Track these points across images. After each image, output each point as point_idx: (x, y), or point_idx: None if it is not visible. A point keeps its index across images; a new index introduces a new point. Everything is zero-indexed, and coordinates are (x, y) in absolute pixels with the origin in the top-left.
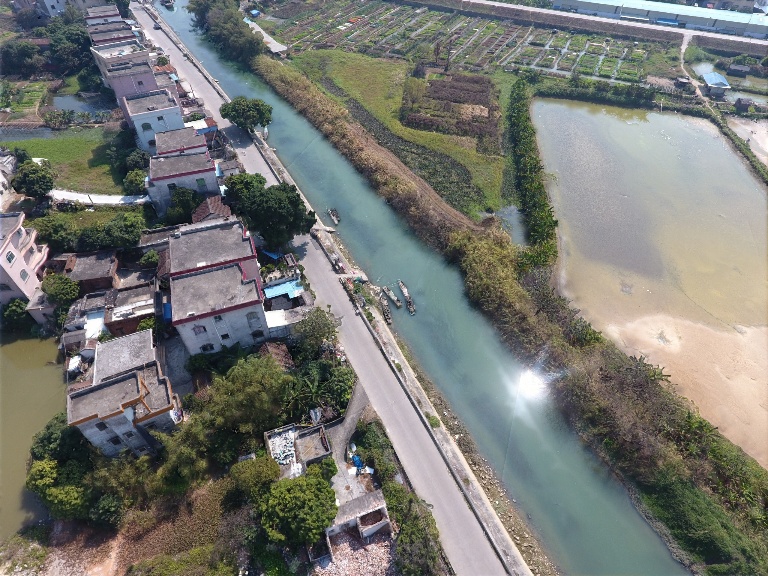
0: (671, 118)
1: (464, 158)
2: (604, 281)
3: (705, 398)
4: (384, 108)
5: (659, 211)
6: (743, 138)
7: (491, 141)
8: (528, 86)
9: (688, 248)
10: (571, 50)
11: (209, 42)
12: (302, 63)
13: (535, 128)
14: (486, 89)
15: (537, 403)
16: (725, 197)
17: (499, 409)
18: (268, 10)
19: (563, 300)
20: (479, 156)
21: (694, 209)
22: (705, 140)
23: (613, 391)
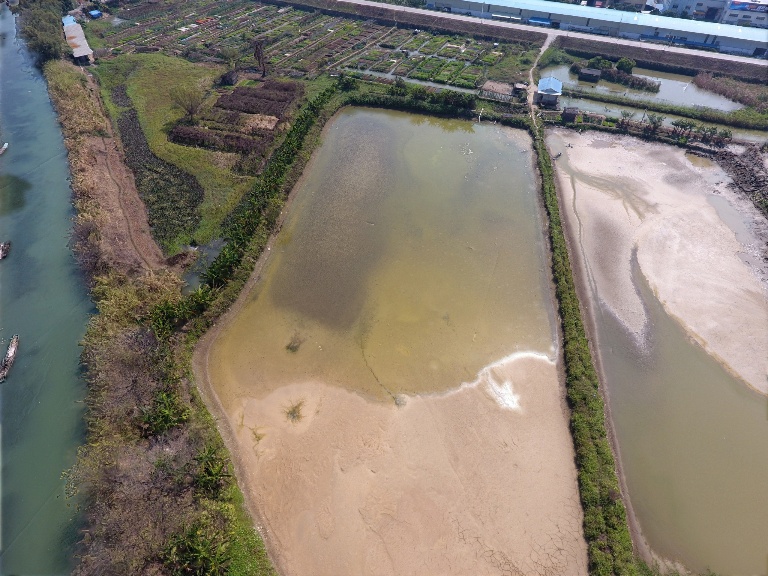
0: (487, 129)
1: (208, 179)
2: (274, 334)
3: (294, 500)
4: (160, 120)
5: (400, 243)
6: (555, 153)
7: (251, 158)
8: (338, 94)
9: (405, 290)
10: (422, 52)
11: (17, 46)
12: (109, 69)
13: (321, 142)
14: (288, 97)
15: (66, 509)
16: (490, 225)
17: (12, 518)
18: (116, 10)
19: (169, 367)
20: (227, 176)
21: (443, 240)
22: (509, 155)
23: (160, 495)
